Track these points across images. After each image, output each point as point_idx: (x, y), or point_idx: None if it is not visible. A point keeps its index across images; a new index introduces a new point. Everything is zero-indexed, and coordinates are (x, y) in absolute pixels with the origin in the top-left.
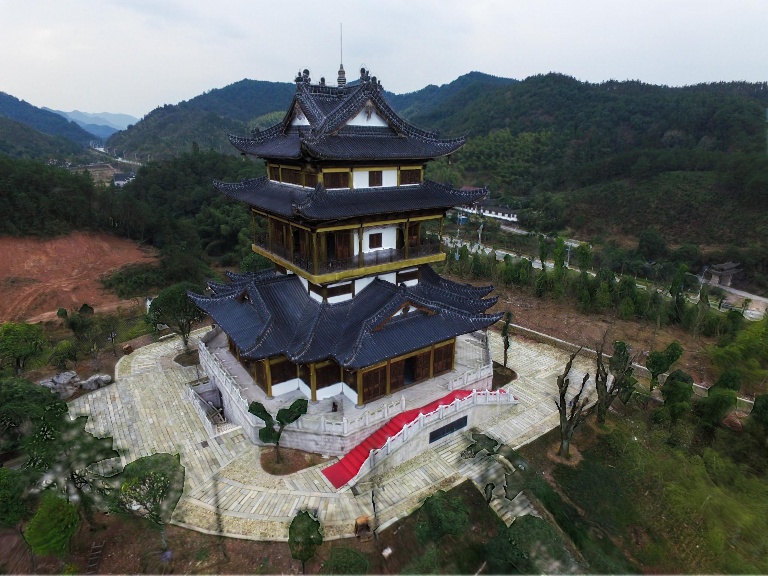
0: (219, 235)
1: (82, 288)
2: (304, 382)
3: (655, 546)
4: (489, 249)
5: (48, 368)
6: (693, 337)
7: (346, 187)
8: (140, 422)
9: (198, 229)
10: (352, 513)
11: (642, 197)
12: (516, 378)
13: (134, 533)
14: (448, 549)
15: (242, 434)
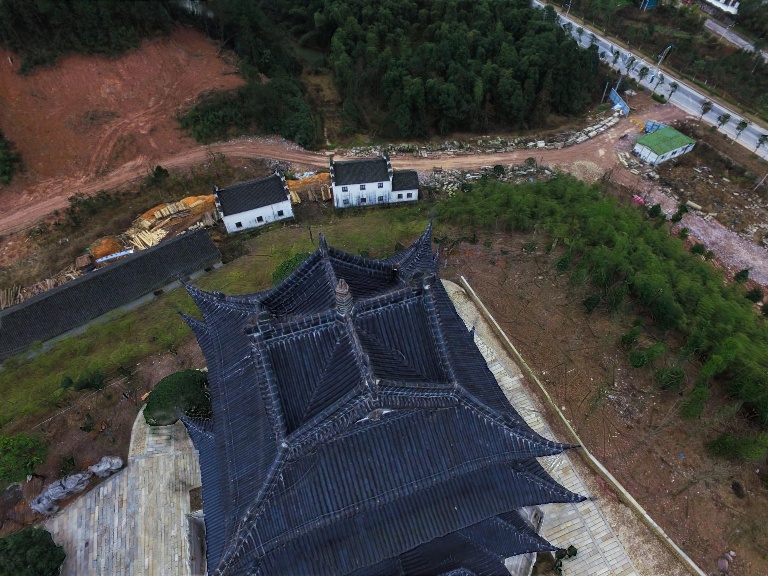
0: (314, 22)
1: (159, 129)
2: None
3: None
4: (668, 78)
5: (73, 417)
6: None
7: None
8: (137, 563)
9: (289, 12)
10: None
11: None
12: None
13: None
14: None
15: None
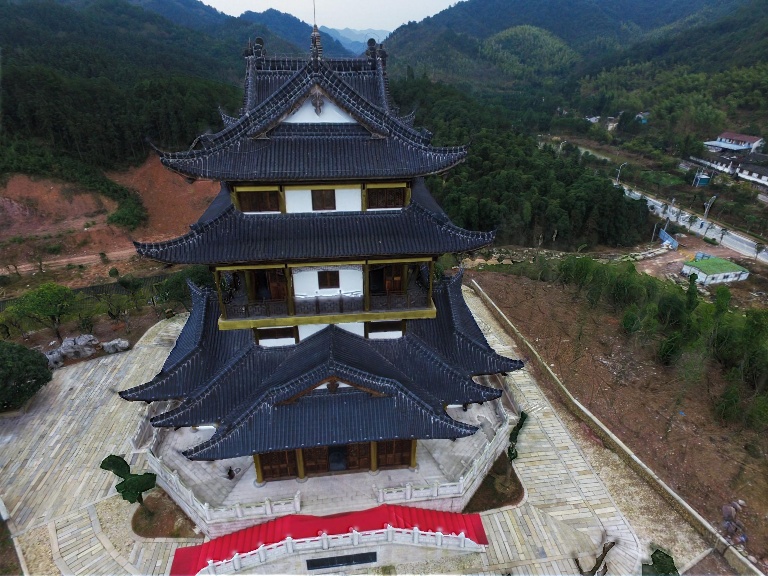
0: None
1: None
2: None
3: None
4: (720, 229)
5: (106, 317)
6: None
7: (276, 210)
8: (105, 407)
9: None
10: None
11: None
12: (516, 503)
13: None
14: None
15: None
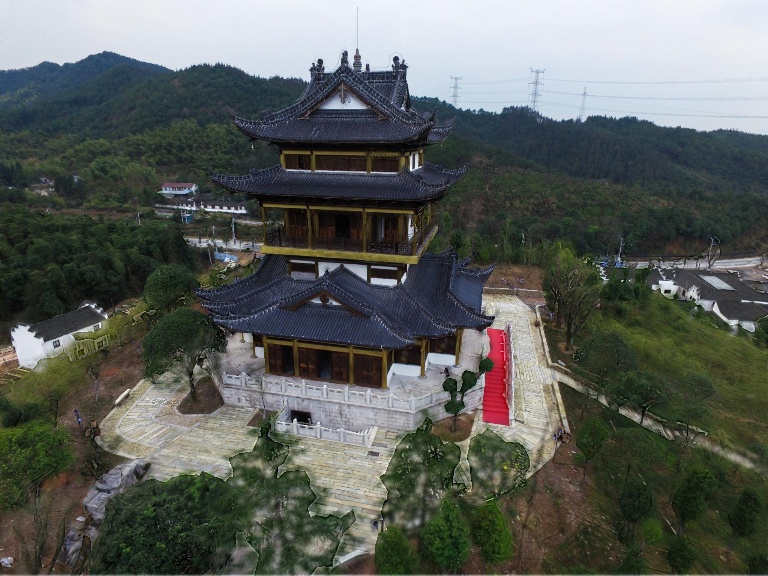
0: None
1: None
2: (405, 364)
3: None
4: None
5: None
6: (542, 263)
7: None
8: None
9: None
10: (539, 433)
11: None
12: None
13: None
14: None
15: (388, 431)
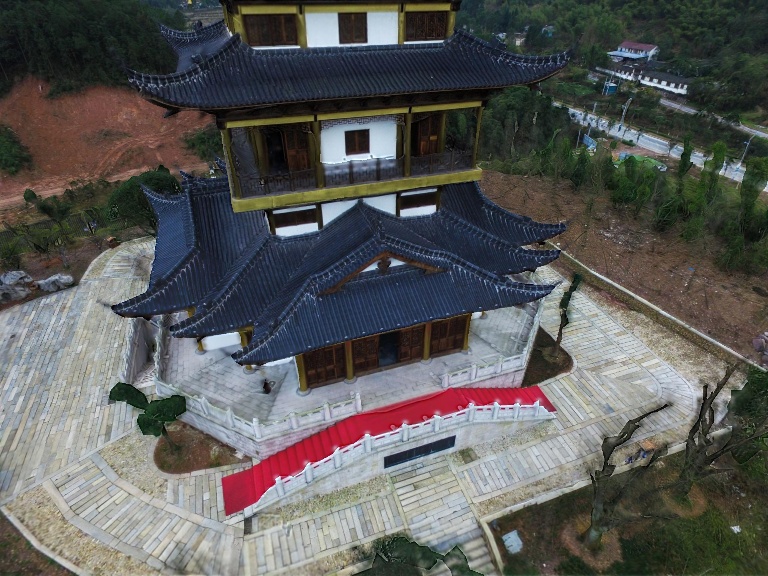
0: None
1: (167, 146)
2: None
3: None
4: (634, 132)
5: (29, 255)
6: None
7: (293, 44)
8: (68, 348)
9: None
10: (225, 566)
11: None
12: (569, 370)
13: None
14: None
15: None
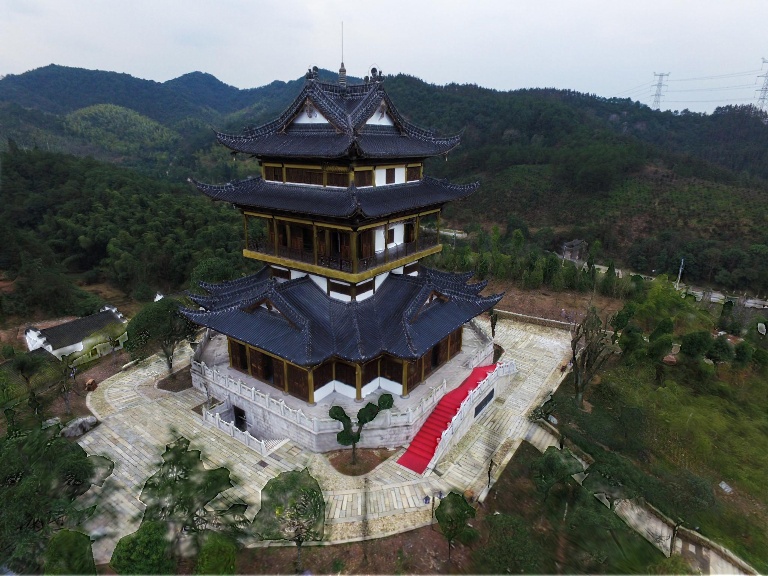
0: (75, 249)
1: None
2: (343, 383)
3: (660, 461)
4: None
5: None
6: (619, 298)
7: (370, 185)
8: None
9: (46, 243)
10: (448, 491)
11: (498, 188)
12: (504, 351)
13: (252, 566)
14: (537, 500)
15: (295, 446)
